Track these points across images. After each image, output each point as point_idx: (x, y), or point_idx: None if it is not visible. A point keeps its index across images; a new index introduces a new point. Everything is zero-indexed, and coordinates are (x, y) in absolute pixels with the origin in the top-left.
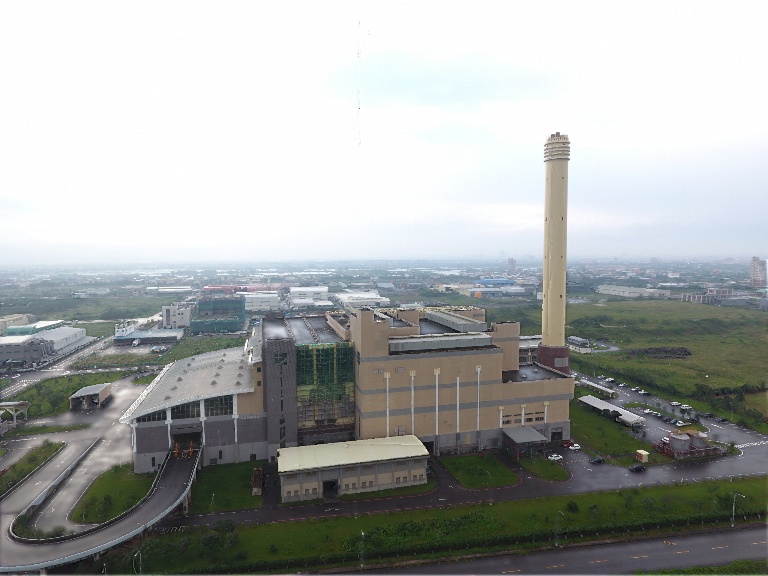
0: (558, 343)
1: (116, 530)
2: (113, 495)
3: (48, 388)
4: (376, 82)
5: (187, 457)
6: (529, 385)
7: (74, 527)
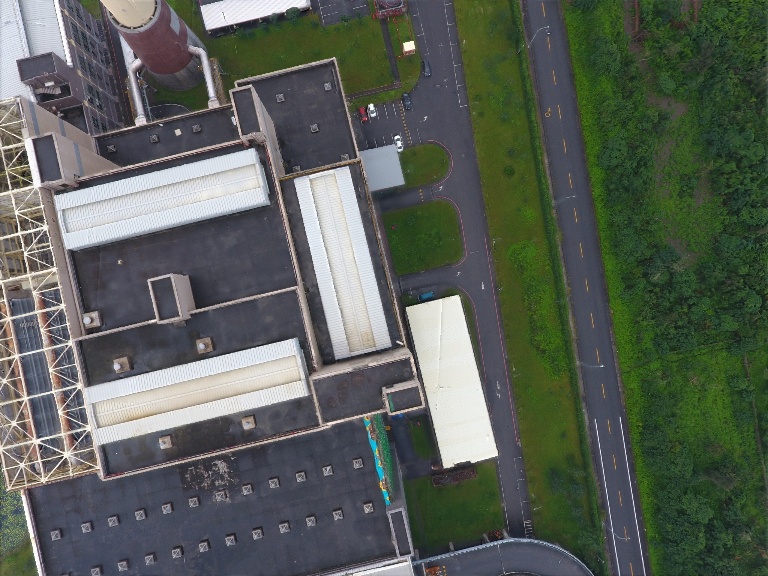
0: None
1: None
2: None
3: None
4: None
5: (444, 569)
6: None
7: None
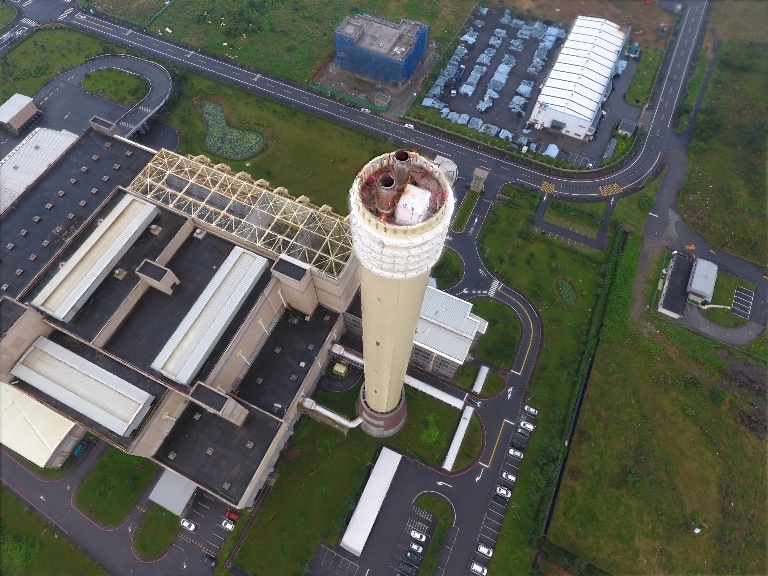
0: (373, 406)
1: None
2: None
3: (7, 69)
4: None
5: None
6: None
7: None
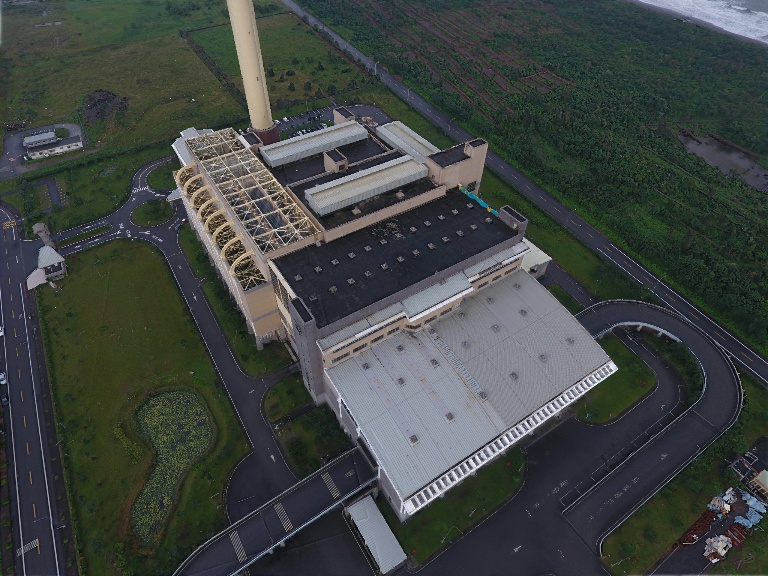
0: None
1: (653, 317)
2: (620, 377)
3: None
4: None
5: None
6: None
7: (658, 371)
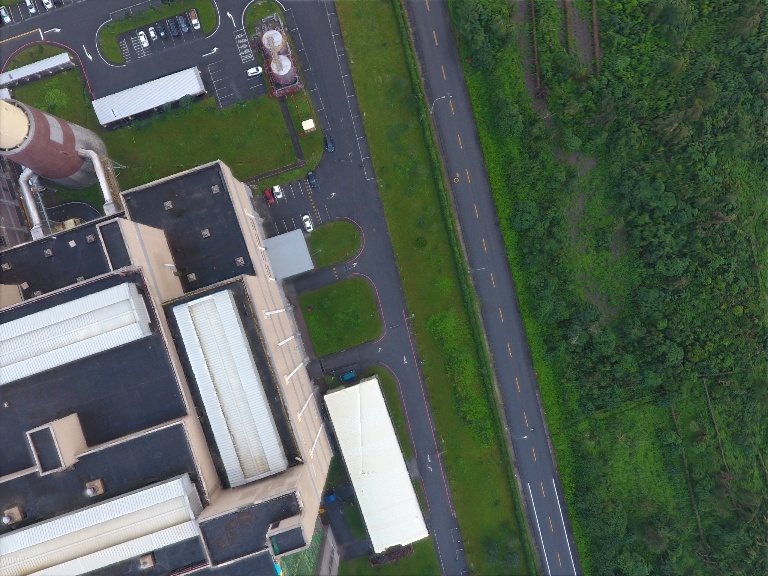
0: (20, 120)
1: None
2: None
3: None
4: None
5: None
6: (246, 235)
7: None
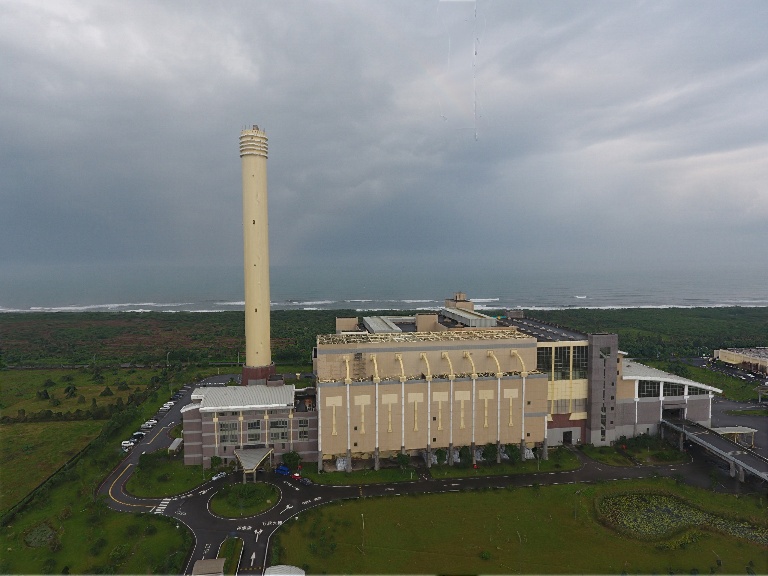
0: None
1: None
2: None
3: None
4: (459, 71)
5: None
6: None
7: None
